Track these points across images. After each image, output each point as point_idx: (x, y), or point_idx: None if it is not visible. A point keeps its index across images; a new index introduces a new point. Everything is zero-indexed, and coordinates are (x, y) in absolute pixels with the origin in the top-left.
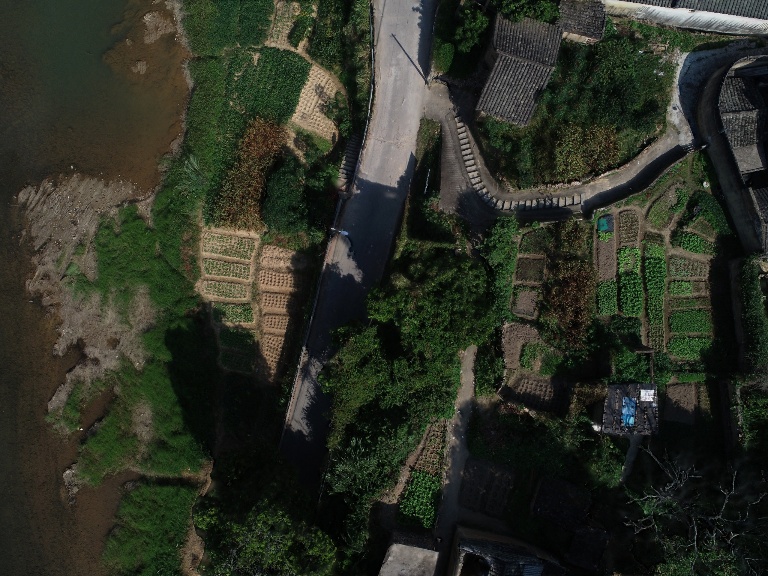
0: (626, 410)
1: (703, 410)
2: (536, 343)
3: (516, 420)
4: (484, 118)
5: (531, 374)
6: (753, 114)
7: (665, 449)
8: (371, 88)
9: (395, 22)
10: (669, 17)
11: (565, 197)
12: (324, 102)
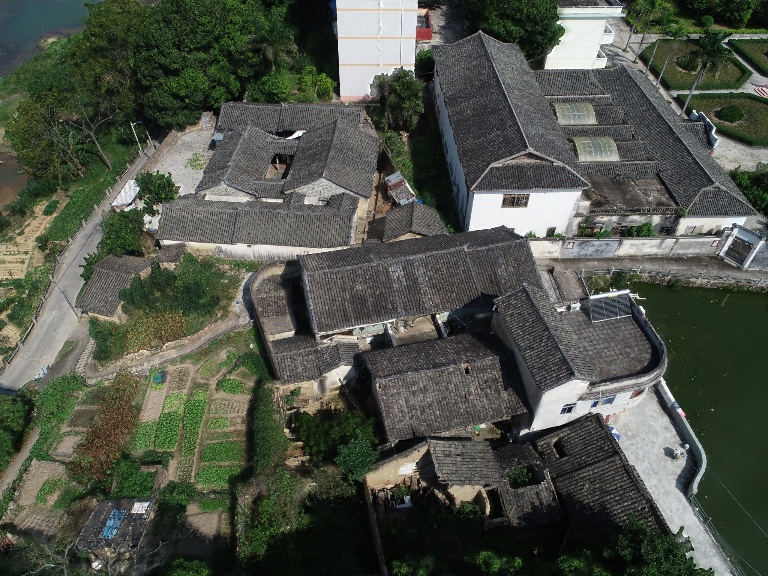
0: (111, 522)
1: (221, 539)
2: (59, 478)
3: (4, 559)
4: (97, 324)
5: (44, 510)
6: (282, 294)
7: (126, 549)
8: (31, 323)
9: (67, 284)
10: (241, 255)
11: (137, 366)
12: (5, 347)
